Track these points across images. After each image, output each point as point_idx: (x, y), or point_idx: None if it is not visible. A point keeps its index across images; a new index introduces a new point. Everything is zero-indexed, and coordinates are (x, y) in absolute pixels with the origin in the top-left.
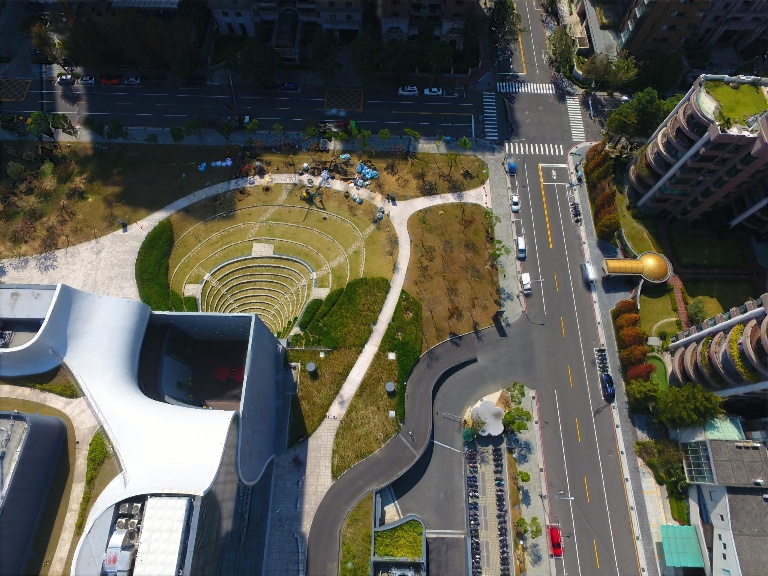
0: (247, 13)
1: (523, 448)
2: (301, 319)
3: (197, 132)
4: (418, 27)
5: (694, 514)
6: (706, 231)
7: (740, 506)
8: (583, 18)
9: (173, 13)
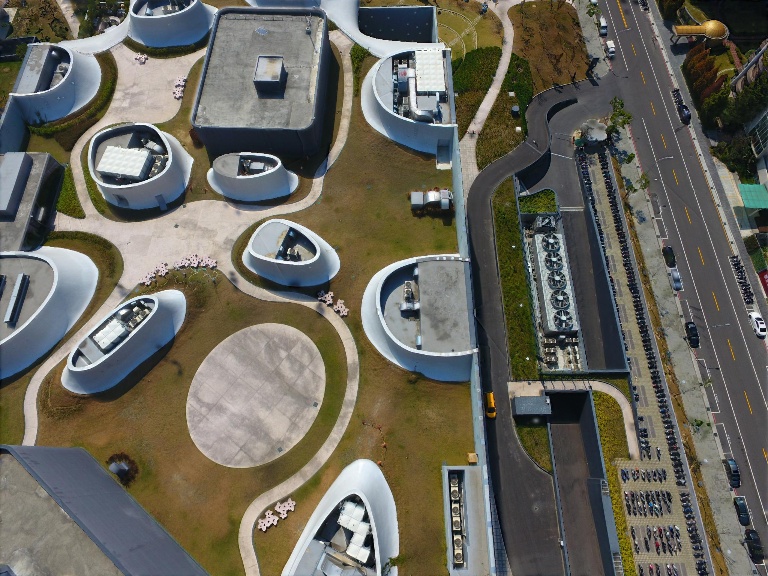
0: None
1: (622, 154)
2: None
3: None
4: None
5: (763, 177)
6: (752, 11)
7: None
8: None
9: None
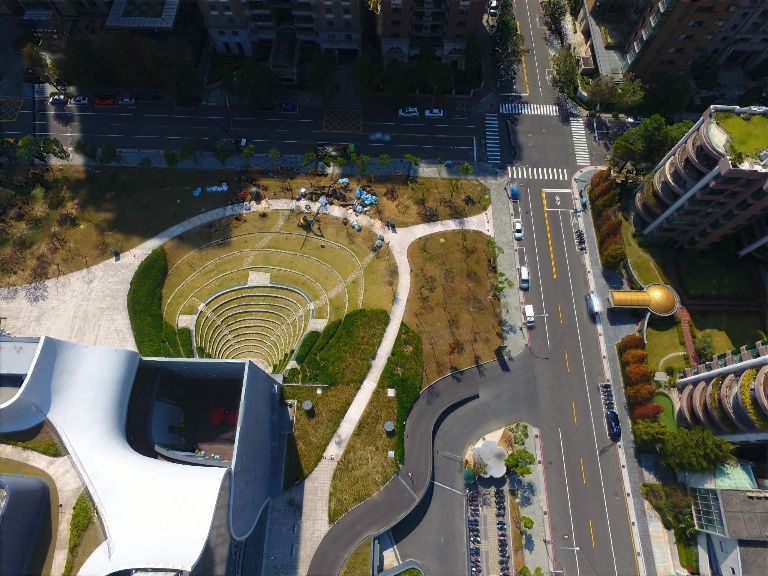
0: (244, 32)
1: (526, 490)
2: (298, 352)
3: (192, 157)
4: (419, 48)
5: (703, 563)
6: (714, 260)
7: (752, 559)
8: (587, 36)
9: (168, 32)
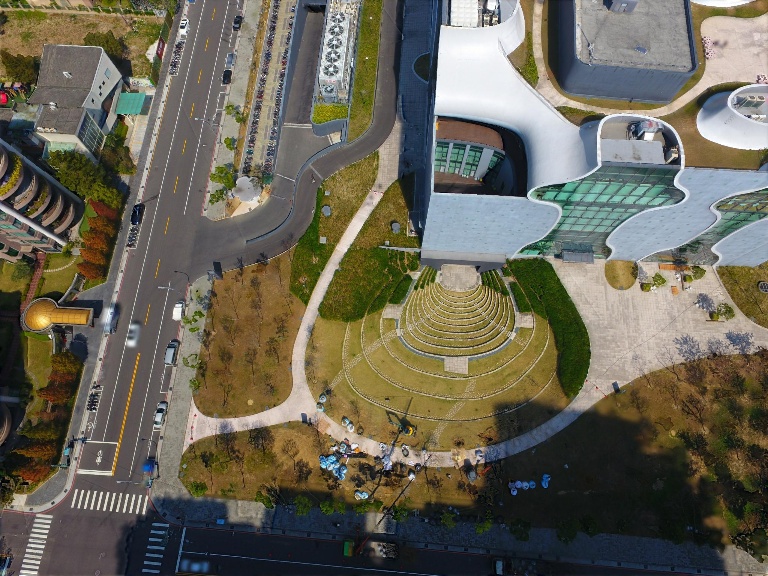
0: None
1: None
2: None
3: None
4: None
5: (112, 119)
6: None
7: (76, 102)
8: None
9: None
